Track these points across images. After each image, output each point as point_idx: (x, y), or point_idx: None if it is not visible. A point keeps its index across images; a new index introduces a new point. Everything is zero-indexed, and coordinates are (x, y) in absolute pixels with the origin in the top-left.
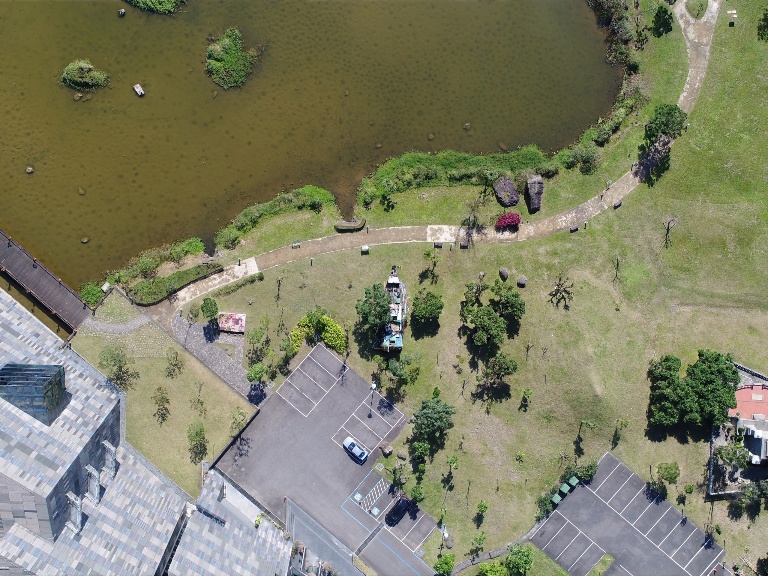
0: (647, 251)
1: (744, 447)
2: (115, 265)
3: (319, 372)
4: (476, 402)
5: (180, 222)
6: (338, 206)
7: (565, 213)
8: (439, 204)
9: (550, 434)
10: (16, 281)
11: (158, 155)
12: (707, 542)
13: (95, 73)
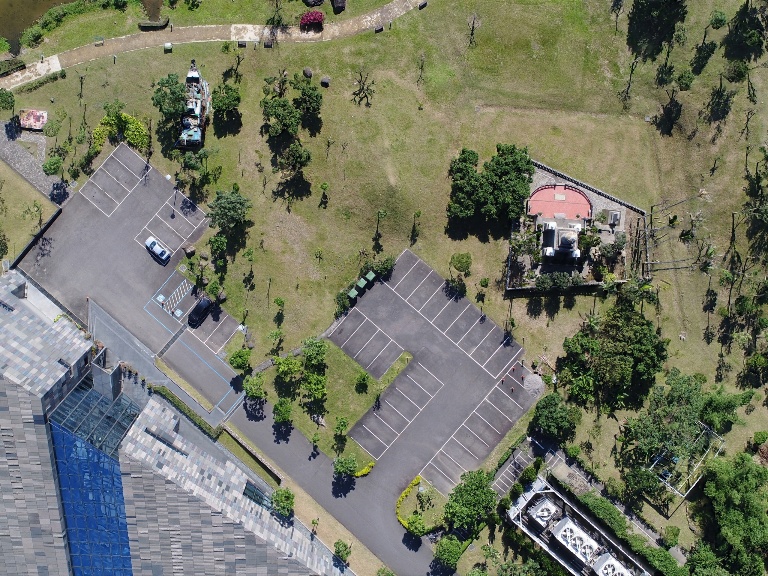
0: (452, 52)
1: (543, 244)
2: None
3: (122, 172)
4: (277, 200)
5: None
6: (144, 7)
7: (370, 13)
8: (244, 3)
9: (349, 231)
10: None
11: None
12: (506, 340)
13: None
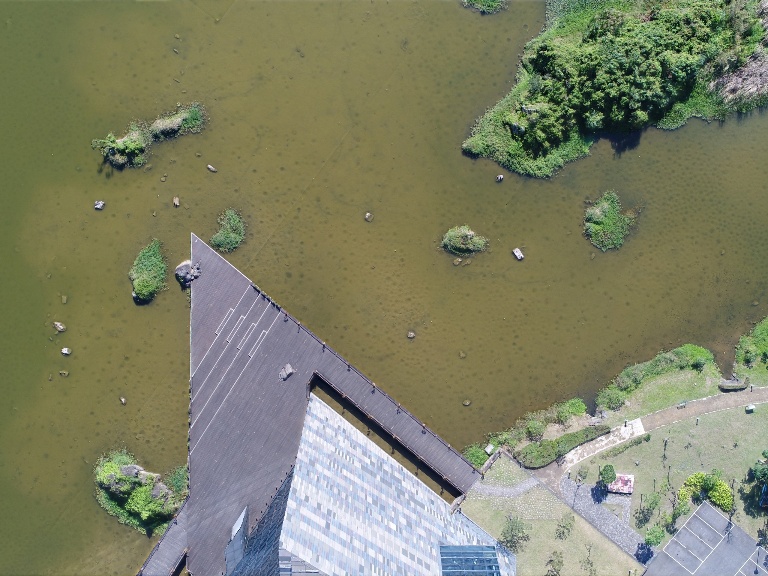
0: None
1: None
2: (497, 427)
3: (705, 530)
4: None
5: (560, 383)
6: (717, 364)
7: None
8: None
9: None
10: (405, 447)
11: (537, 317)
12: None
13: (475, 239)
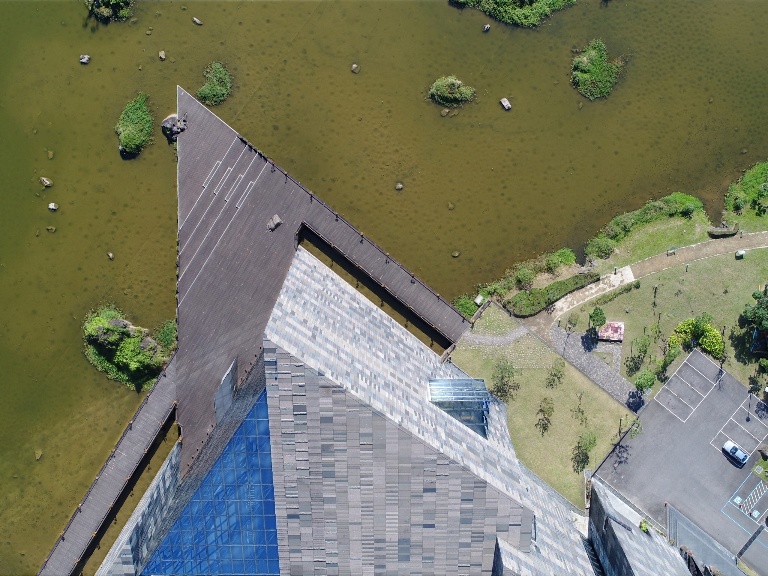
0: None
1: None
2: (486, 278)
3: (696, 377)
4: None
5: (549, 233)
6: (706, 212)
7: None
8: None
9: None
10: (394, 297)
11: (526, 167)
12: None
13: (463, 88)
